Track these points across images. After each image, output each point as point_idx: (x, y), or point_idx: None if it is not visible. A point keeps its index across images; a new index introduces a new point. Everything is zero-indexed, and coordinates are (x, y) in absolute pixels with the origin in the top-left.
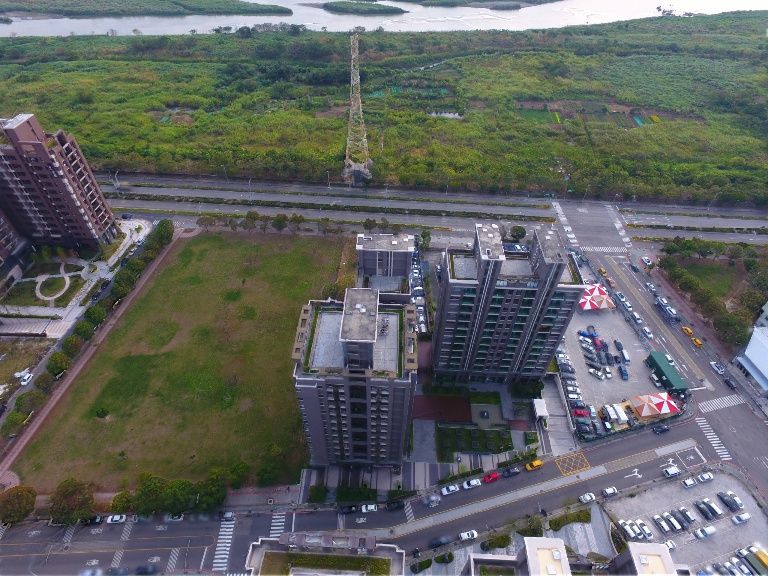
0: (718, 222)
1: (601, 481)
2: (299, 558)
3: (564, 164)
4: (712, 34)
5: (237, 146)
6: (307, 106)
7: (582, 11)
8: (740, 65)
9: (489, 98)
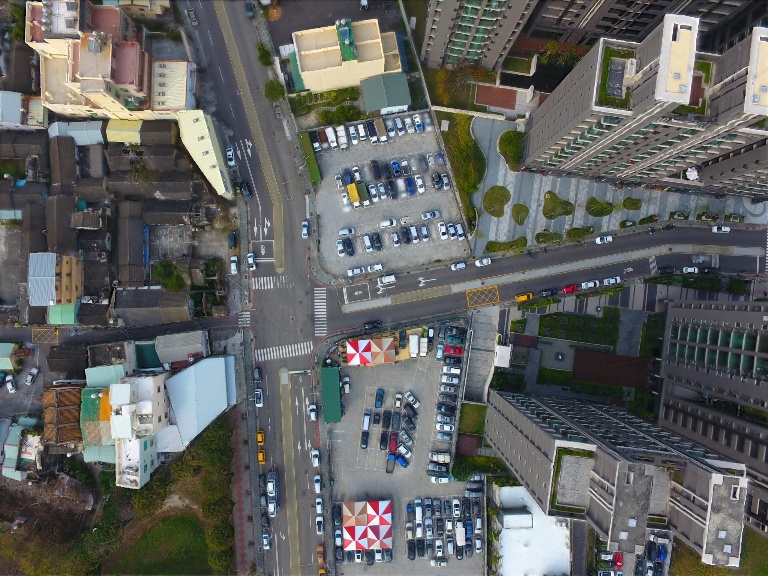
0: None
1: (462, 277)
2: None
3: None
4: None
5: None
6: None
7: None
8: None
9: None
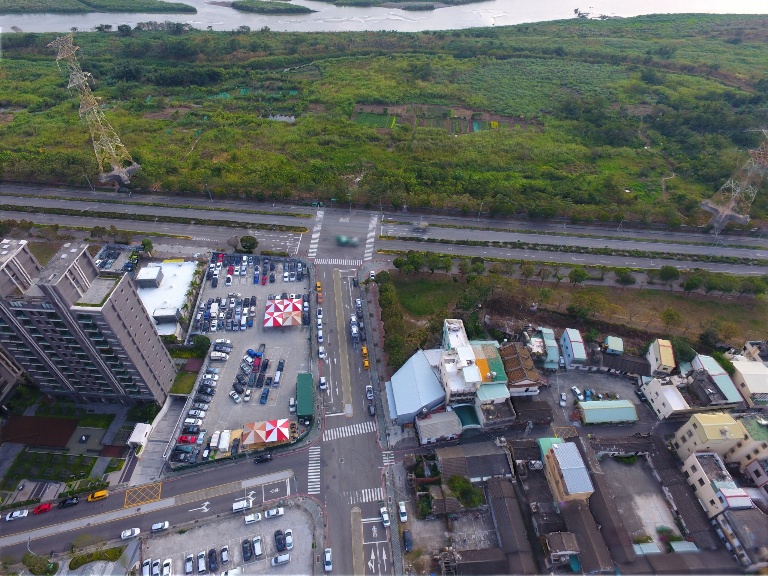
0: (479, 235)
1: (160, 515)
2: None
3: (369, 171)
4: (610, 38)
5: (39, 147)
6: (138, 107)
7: (491, 13)
8: (617, 70)
9: (328, 101)
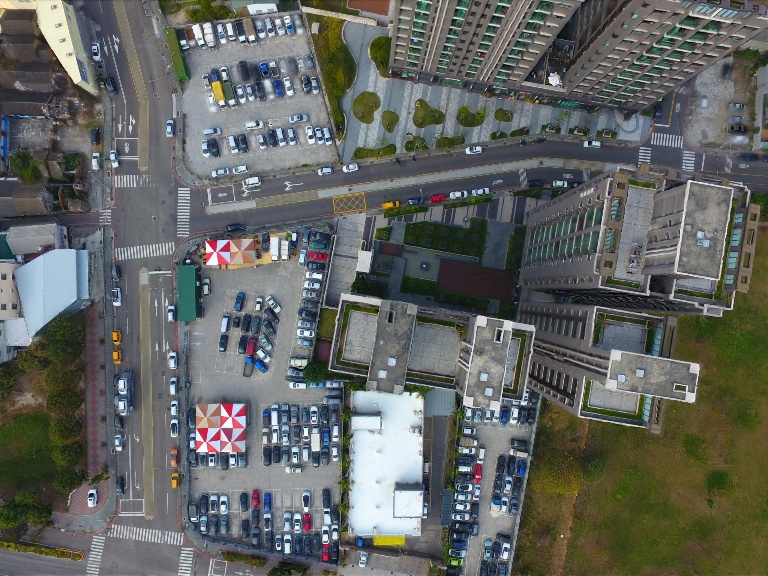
0: None
1: (329, 183)
2: None
3: None
4: None
5: None
6: None
7: None
8: None
9: None
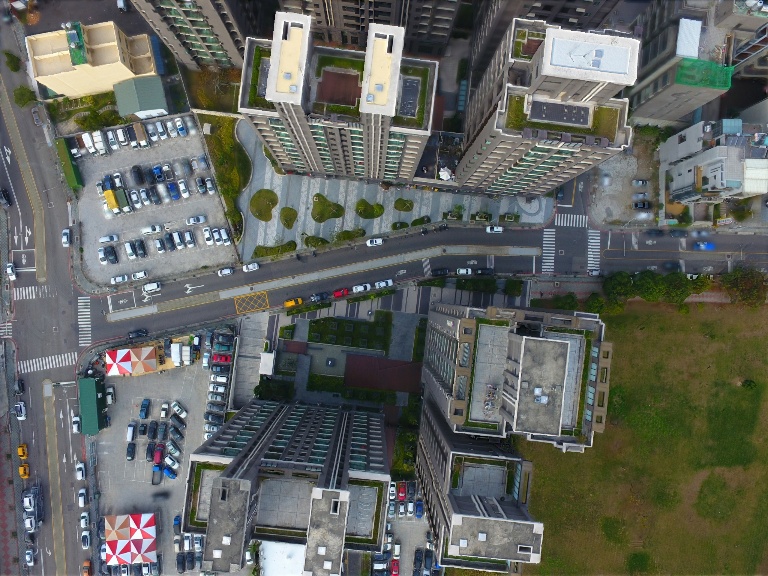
0: None
1: (230, 283)
2: (585, 134)
3: None
4: None
5: None
6: None
7: None
8: None
9: None
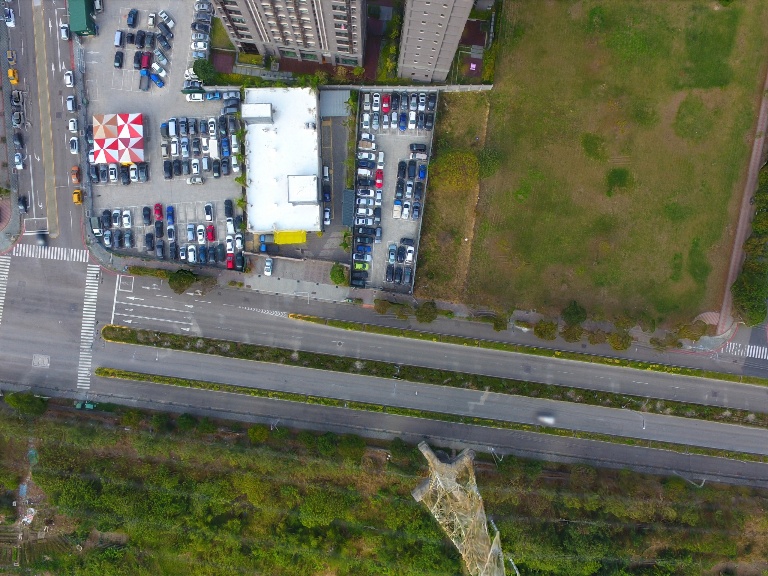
0: None
1: None
2: None
3: (8, 554)
4: None
5: None
6: None
7: None
8: None
9: None
